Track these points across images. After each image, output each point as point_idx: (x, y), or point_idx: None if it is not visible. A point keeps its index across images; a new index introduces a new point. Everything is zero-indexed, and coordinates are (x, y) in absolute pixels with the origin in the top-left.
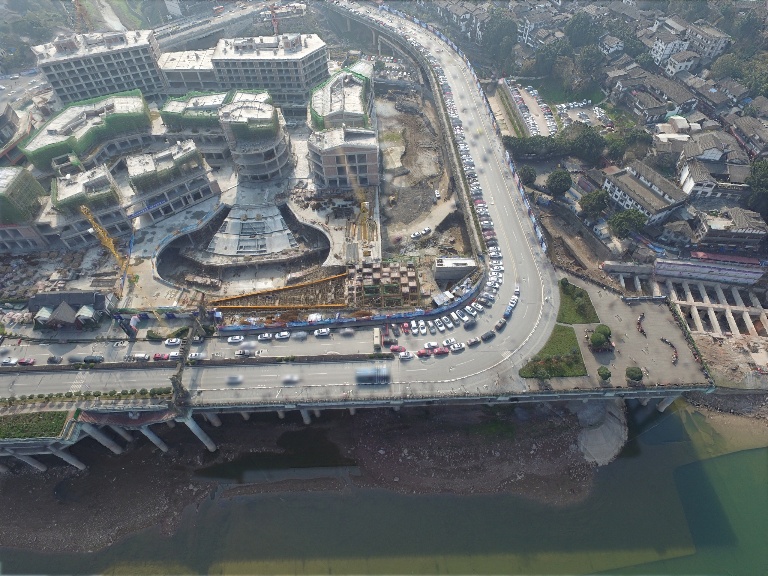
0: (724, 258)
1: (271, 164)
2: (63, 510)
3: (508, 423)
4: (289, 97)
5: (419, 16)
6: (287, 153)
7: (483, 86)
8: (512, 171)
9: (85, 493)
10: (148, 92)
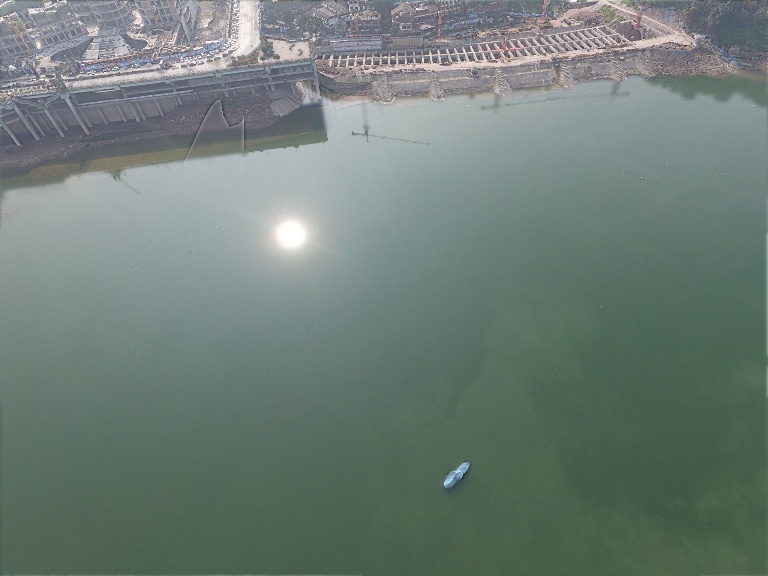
0: (361, 35)
1: (116, 14)
2: (11, 156)
3: (234, 101)
4: None
5: None
6: (126, 11)
7: None
8: None
9: (22, 151)
10: None
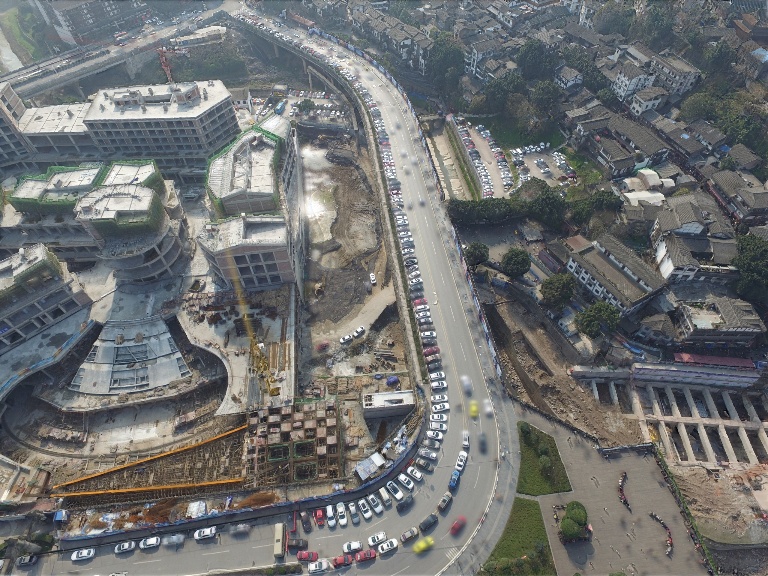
0: (713, 361)
1: (155, 264)
2: None
3: None
4: (188, 161)
5: (354, 41)
6: (178, 245)
7: (429, 123)
8: (459, 254)
9: None
10: (8, 161)
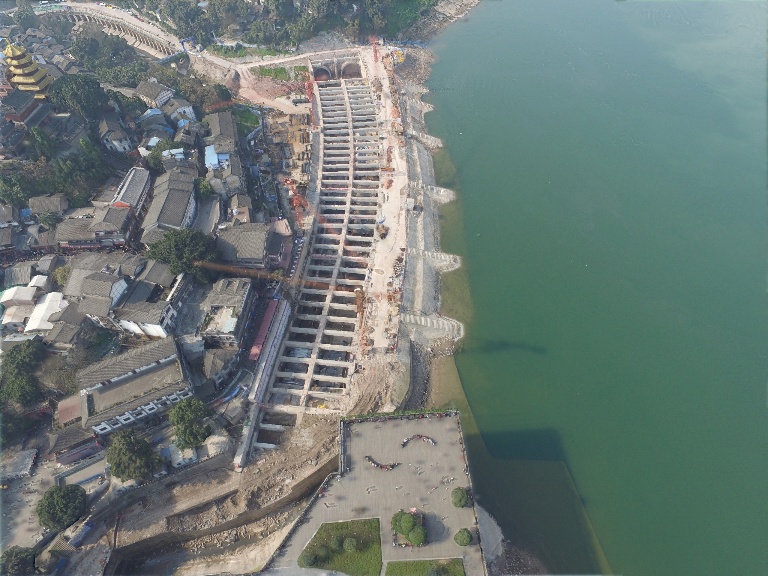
0: (265, 329)
1: None
2: None
3: None
4: None
5: None
6: None
7: None
8: None
9: None
10: None
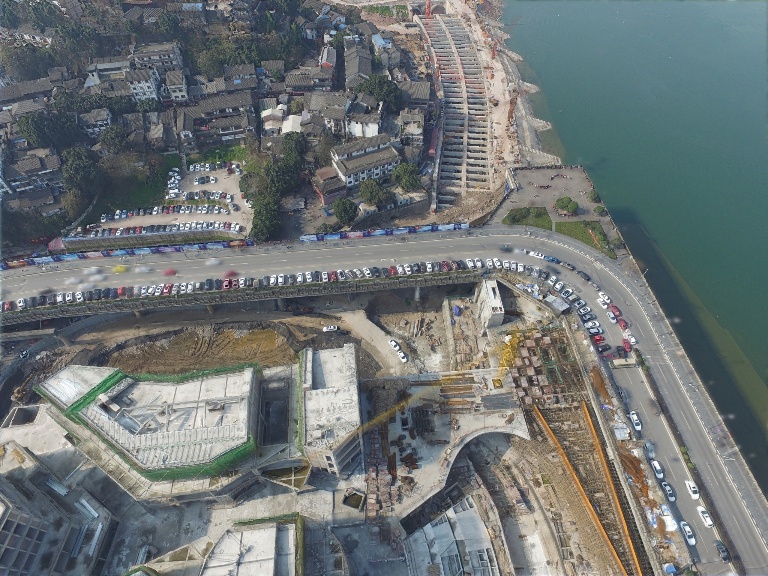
0: (435, 142)
1: None
2: None
3: None
4: (57, 567)
5: None
6: None
7: None
8: (338, 238)
9: None
10: None
